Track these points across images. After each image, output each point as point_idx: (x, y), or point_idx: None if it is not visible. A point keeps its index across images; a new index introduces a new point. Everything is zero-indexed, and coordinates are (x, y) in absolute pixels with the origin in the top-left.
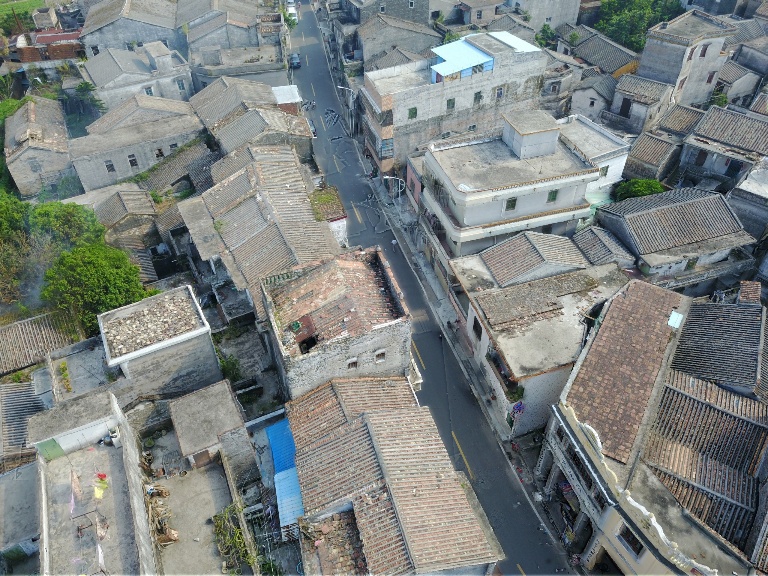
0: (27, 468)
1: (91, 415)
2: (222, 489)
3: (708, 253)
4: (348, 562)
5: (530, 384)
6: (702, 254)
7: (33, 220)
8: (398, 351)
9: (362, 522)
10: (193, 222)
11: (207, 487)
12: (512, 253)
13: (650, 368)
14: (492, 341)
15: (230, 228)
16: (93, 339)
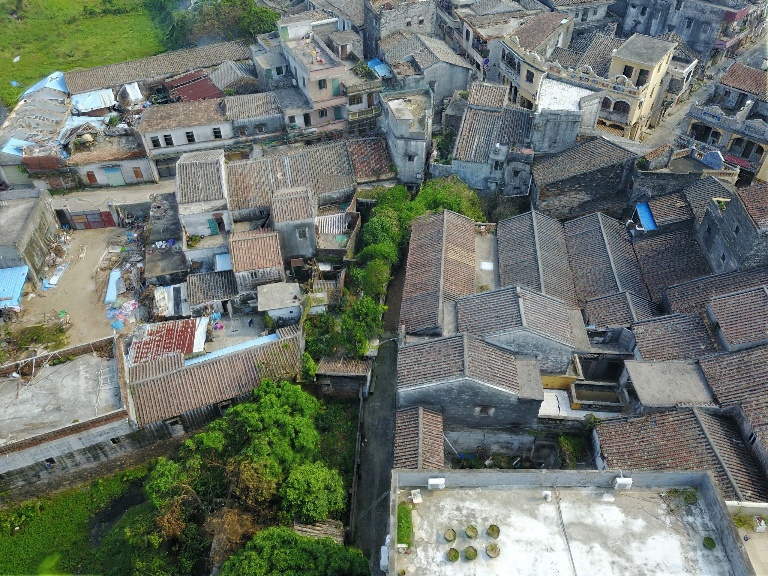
0: (269, 53)
1: (302, 19)
2: (353, 64)
3: (589, 6)
4: (411, 69)
5: (491, 48)
6: (585, 6)
7: (222, 4)
8: (429, 20)
9: (416, 57)
10: (313, 1)
11: (346, 63)
12: (485, 3)
13: (547, 31)
14: (474, 33)
15: (335, 0)
16: (277, 32)
